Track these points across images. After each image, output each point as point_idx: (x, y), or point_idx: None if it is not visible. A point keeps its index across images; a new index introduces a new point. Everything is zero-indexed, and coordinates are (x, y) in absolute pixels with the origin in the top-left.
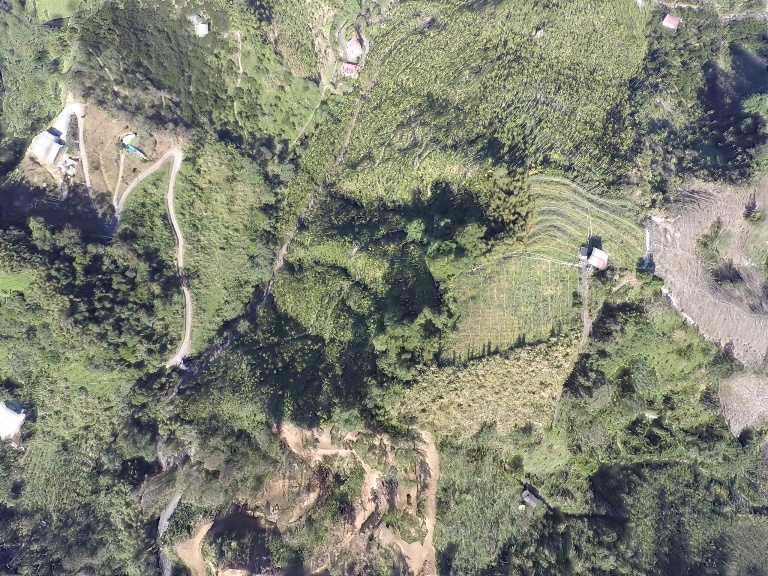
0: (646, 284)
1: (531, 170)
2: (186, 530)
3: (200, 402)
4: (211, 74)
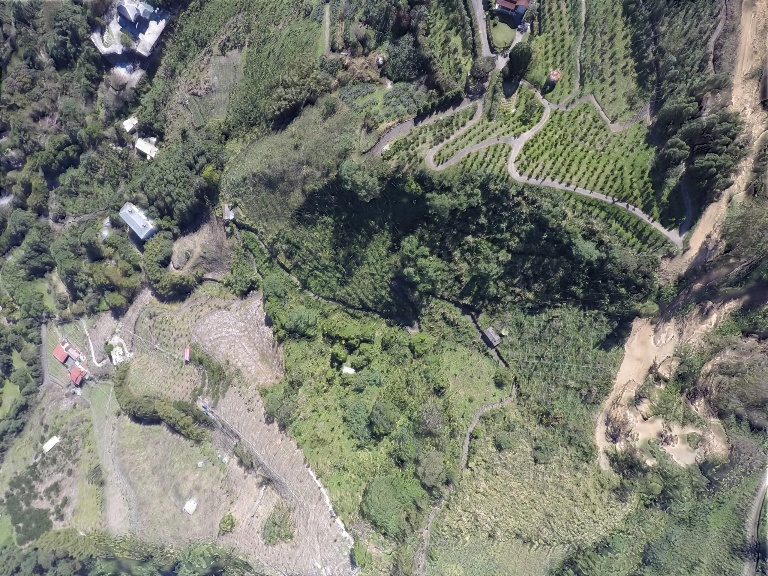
0: None
1: None
2: None
3: None
4: None
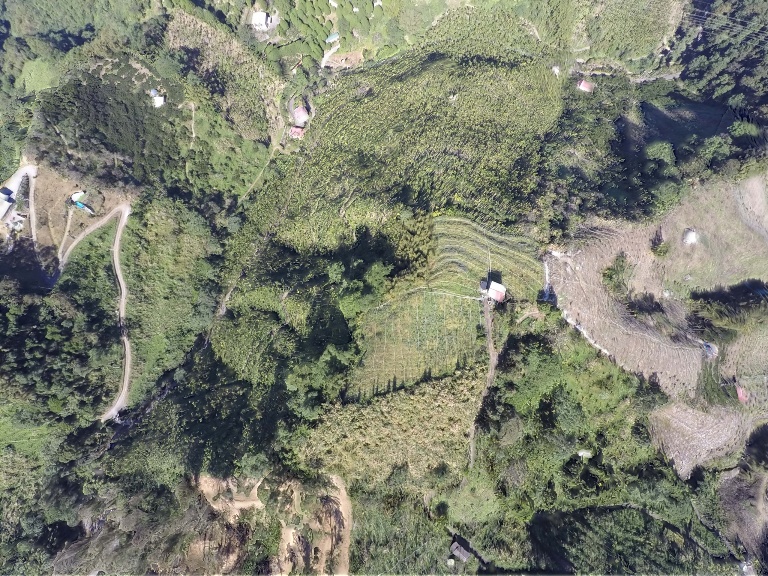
0: (547, 315)
1: (435, 212)
2: None
3: (126, 456)
4: (165, 138)
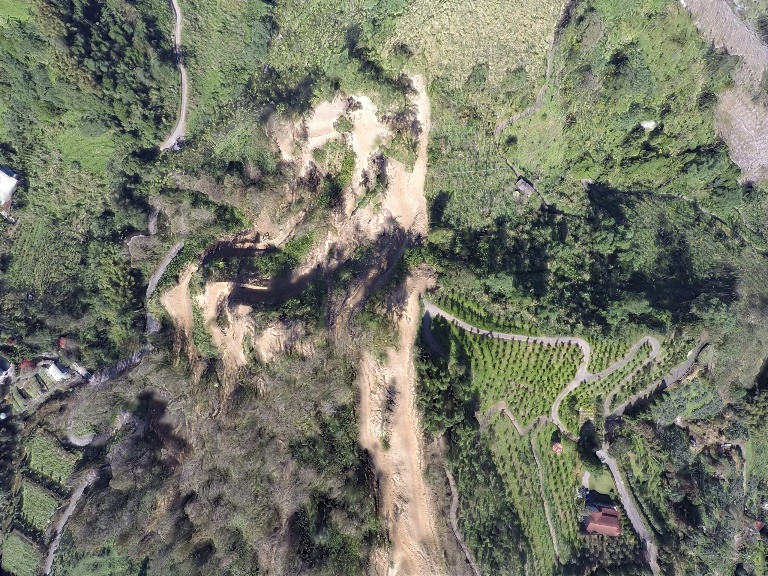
0: None
1: None
2: (174, 278)
3: None
4: None
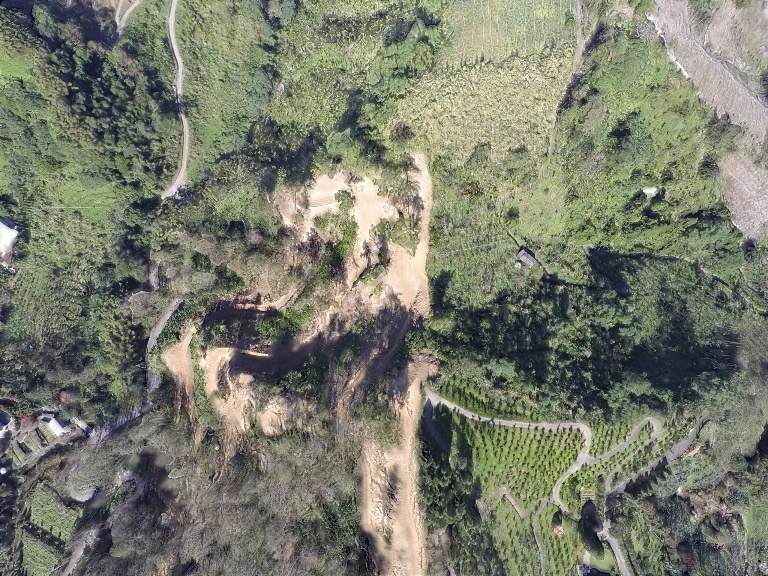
0: (638, 5)
1: None
2: (175, 335)
3: None
4: None
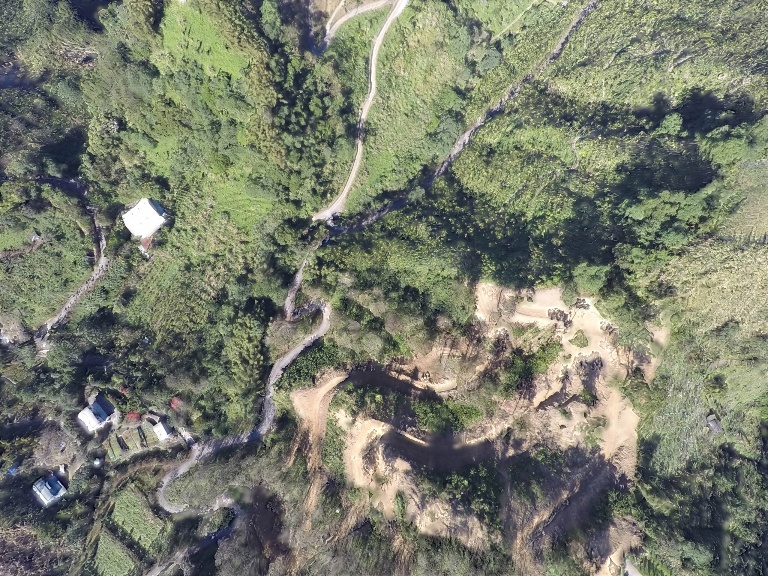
0: None
1: None
2: (312, 379)
3: (363, 252)
4: None
